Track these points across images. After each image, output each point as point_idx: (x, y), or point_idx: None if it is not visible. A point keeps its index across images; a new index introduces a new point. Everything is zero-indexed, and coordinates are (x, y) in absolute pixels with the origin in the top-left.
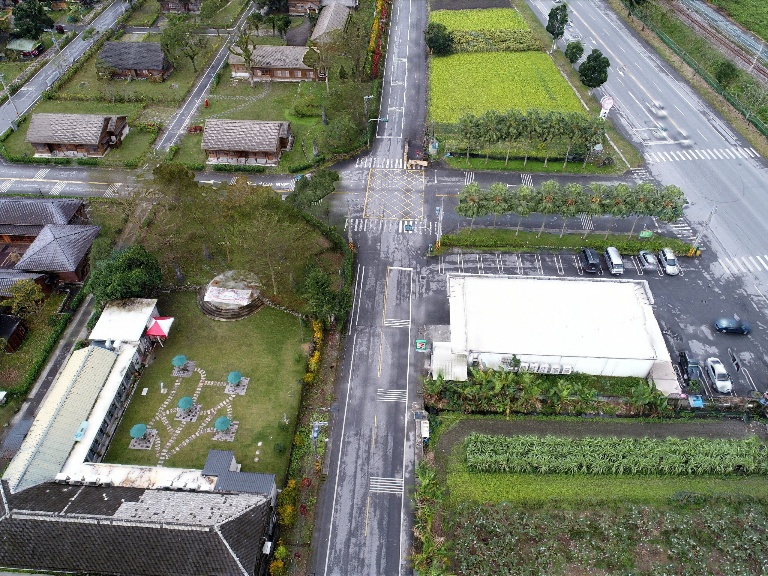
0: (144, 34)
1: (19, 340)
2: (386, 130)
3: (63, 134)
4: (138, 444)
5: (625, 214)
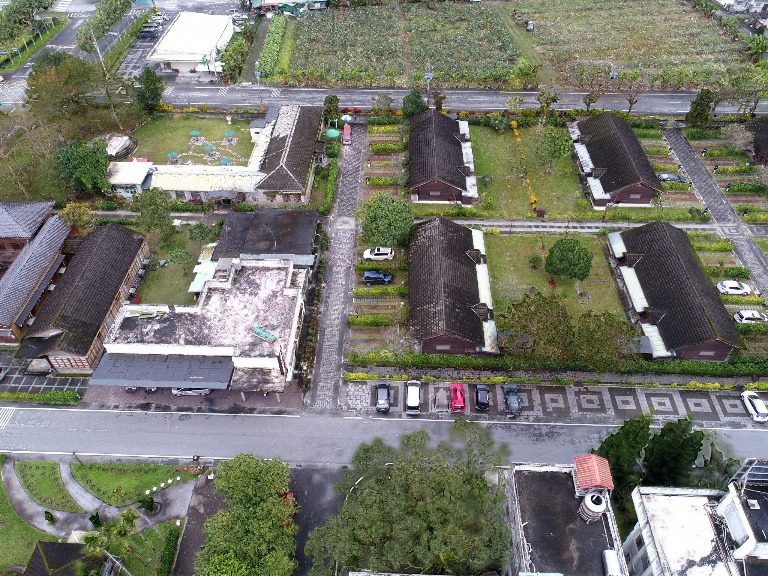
0: None
1: None
2: None
3: None
4: None
5: (133, 1)
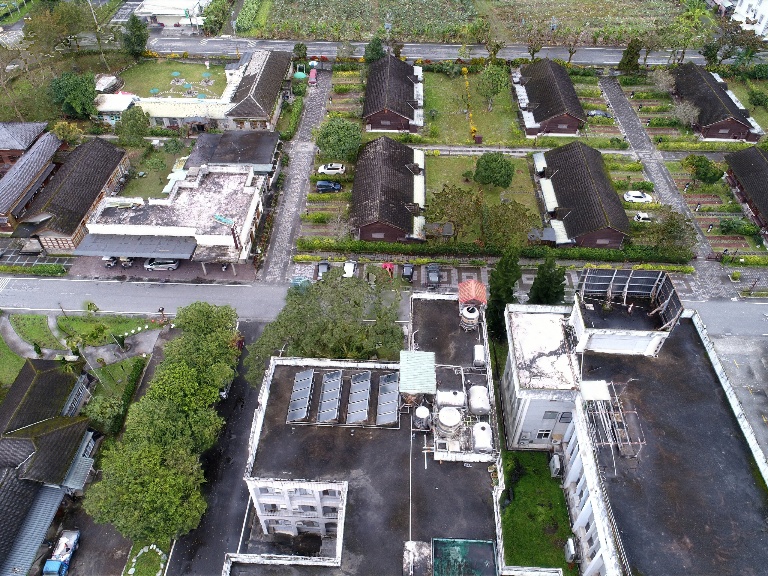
0: None
1: None
2: None
3: None
4: None
5: None
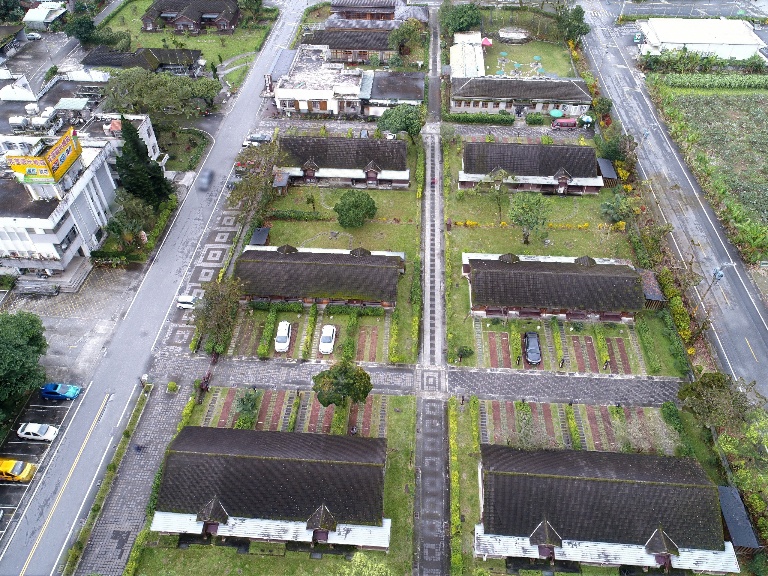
0: None
1: (409, 50)
2: None
3: None
4: None
5: None
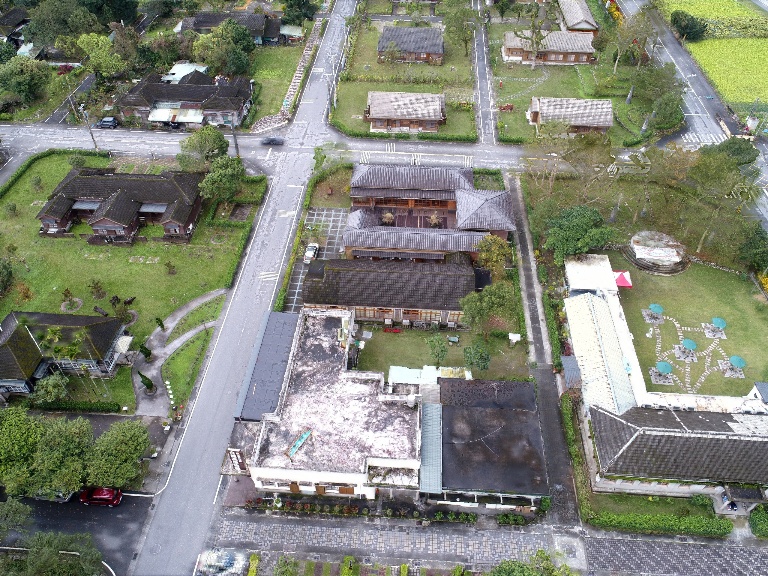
0: (390, 21)
1: None
2: (690, 108)
3: (405, 110)
4: (659, 380)
5: None
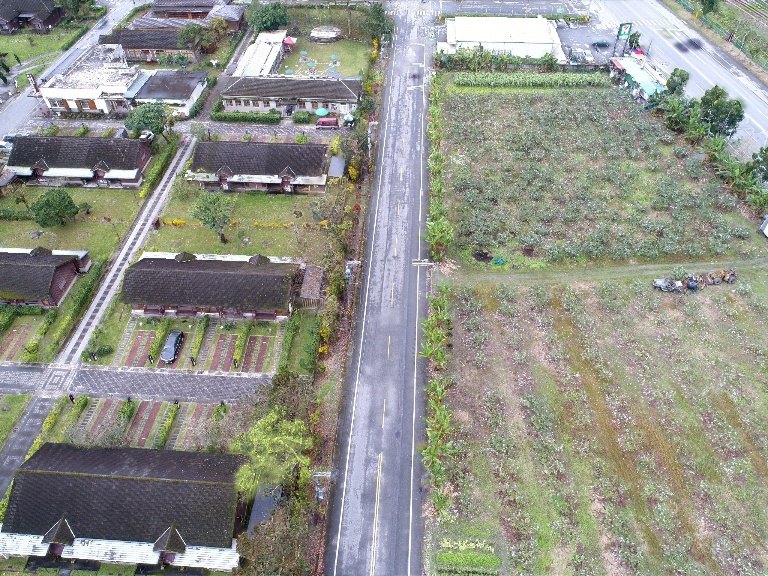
0: None
1: (214, 49)
2: None
3: None
4: None
5: None
